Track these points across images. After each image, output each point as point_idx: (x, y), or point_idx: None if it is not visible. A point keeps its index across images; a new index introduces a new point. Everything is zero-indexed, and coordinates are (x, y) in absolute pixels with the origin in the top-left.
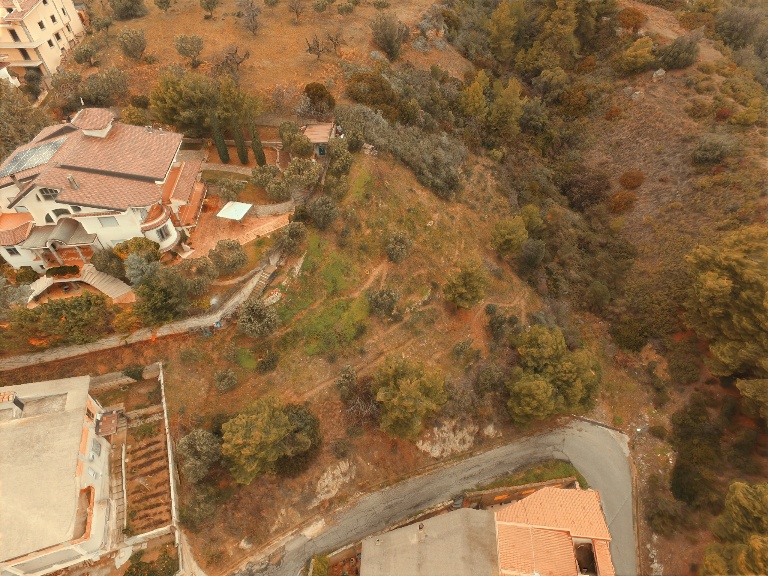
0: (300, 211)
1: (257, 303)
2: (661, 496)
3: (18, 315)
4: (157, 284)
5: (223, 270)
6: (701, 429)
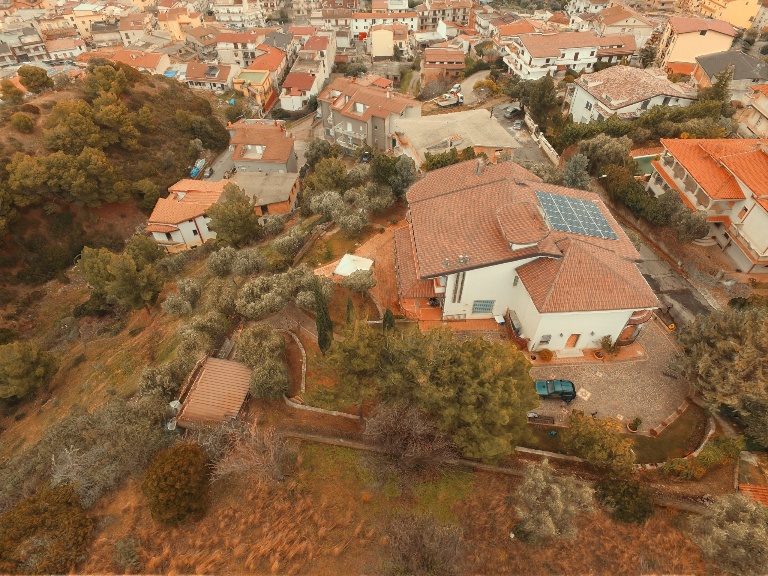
0: None
1: (325, 199)
2: None
3: (473, 150)
4: (387, 164)
5: (361, 233)
6: (38, 261)
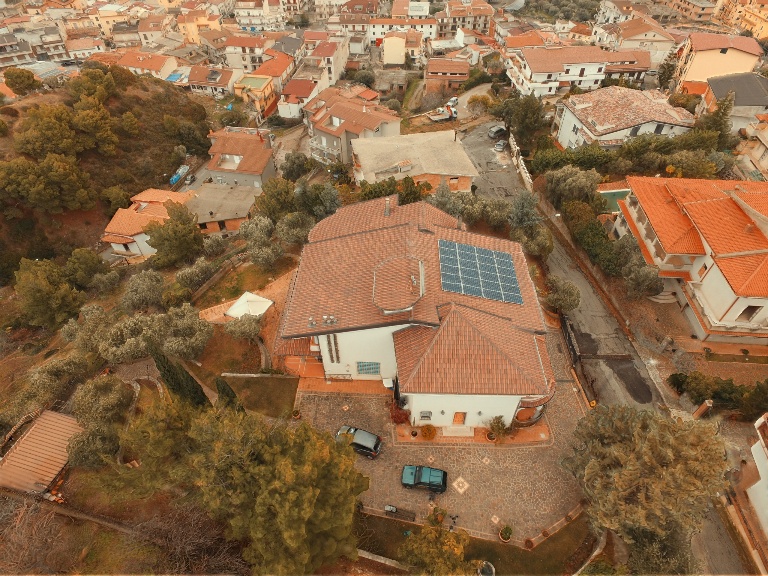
0: (171, 296)
1: (251, 225)
2: (62, 260)
3: (412, 180)
4: (315, 192)
5: (279, 266)
6: None
